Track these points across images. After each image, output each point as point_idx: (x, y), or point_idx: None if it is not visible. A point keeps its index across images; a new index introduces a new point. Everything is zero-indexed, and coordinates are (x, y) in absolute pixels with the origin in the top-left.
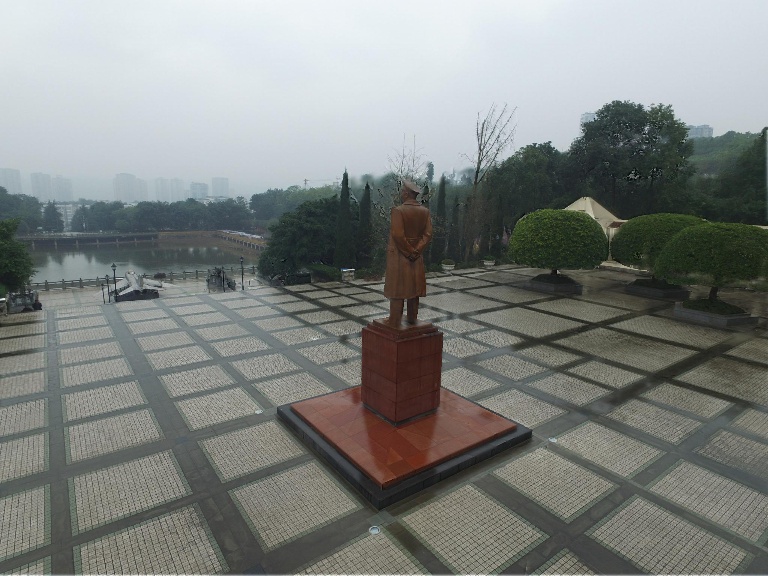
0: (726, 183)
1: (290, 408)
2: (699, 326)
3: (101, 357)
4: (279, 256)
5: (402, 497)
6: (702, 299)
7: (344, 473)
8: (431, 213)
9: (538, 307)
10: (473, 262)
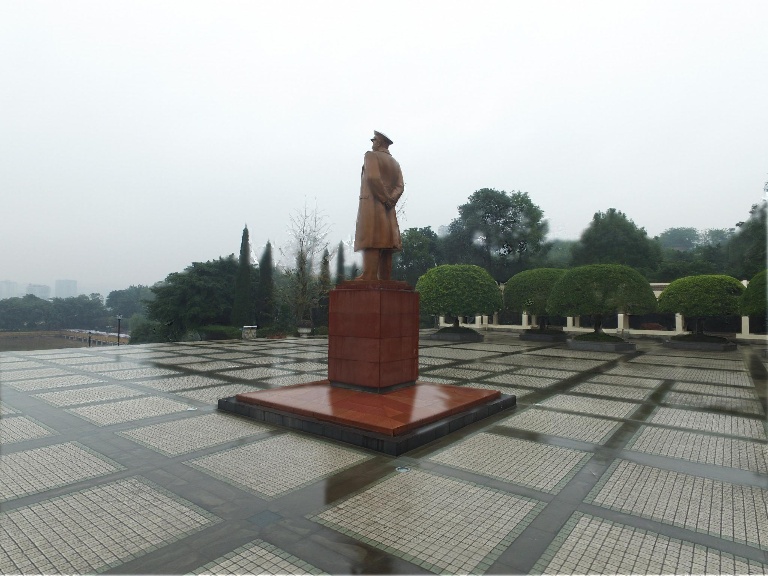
0: (576, 255)
1: (236, 398)
2: (595, 351)
3: None
4: (164, 319)
5: (417, 444)
6: None
7: (336, 433)
8: (331, 277)
9: (453, 347)
10: None
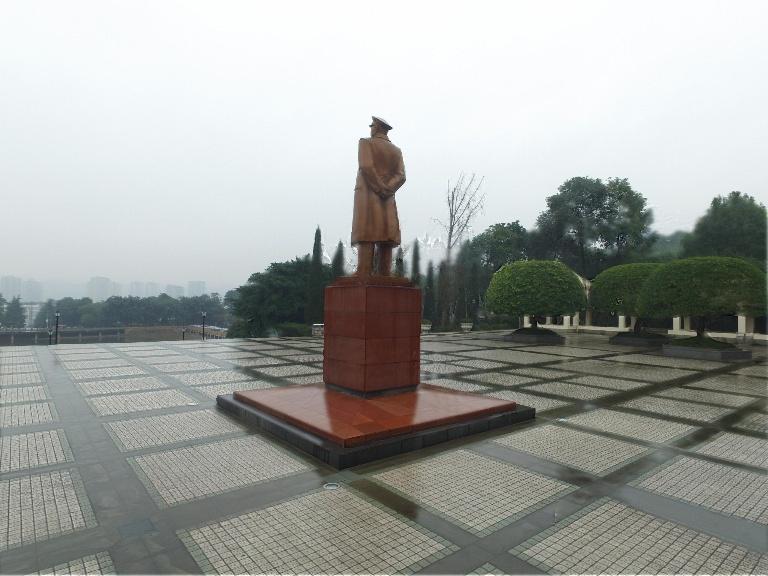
0: (688, 248)
1: (233, 396)
2: (693, 359)
3: (10, 372)
4: (246, 316)
5: (372, 458)
6: None
7: (294, 439)
8: (406, 275)
9: (522, 349)
10: (450, 326)
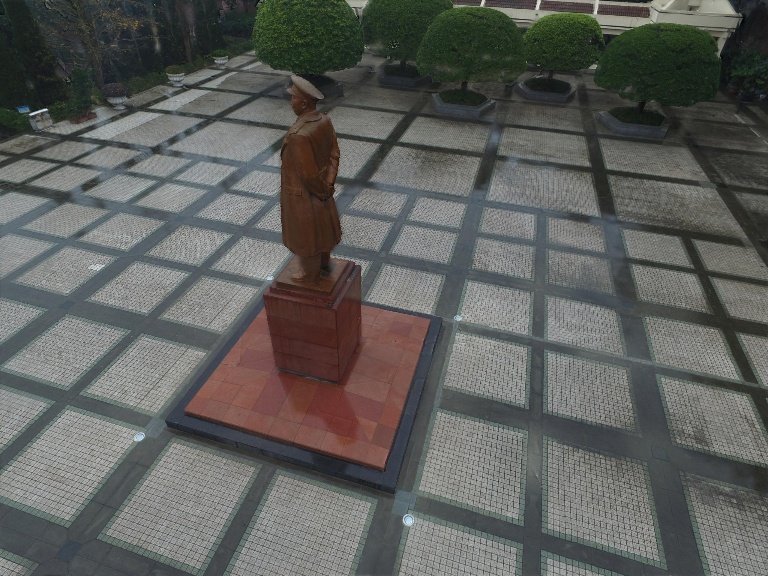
0: None
1: (185, 414)
2: (462, 122)
3: None
4: None
5: (402, 465)
6: (456, 90)
7: (329, 472)
8: None
9: None
10: (199, 61)
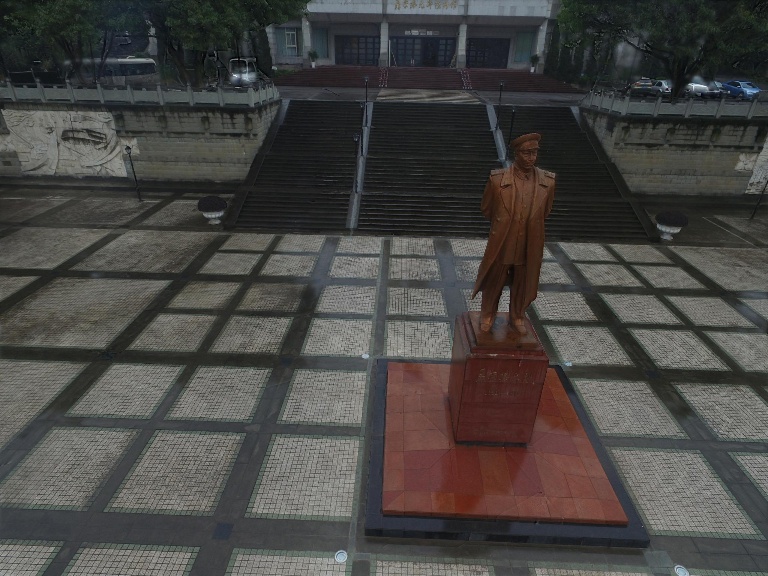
0: None
1: None
2: None
3: None
4: None
5: None
6: None
7: None
8: None
9: None
10: None
